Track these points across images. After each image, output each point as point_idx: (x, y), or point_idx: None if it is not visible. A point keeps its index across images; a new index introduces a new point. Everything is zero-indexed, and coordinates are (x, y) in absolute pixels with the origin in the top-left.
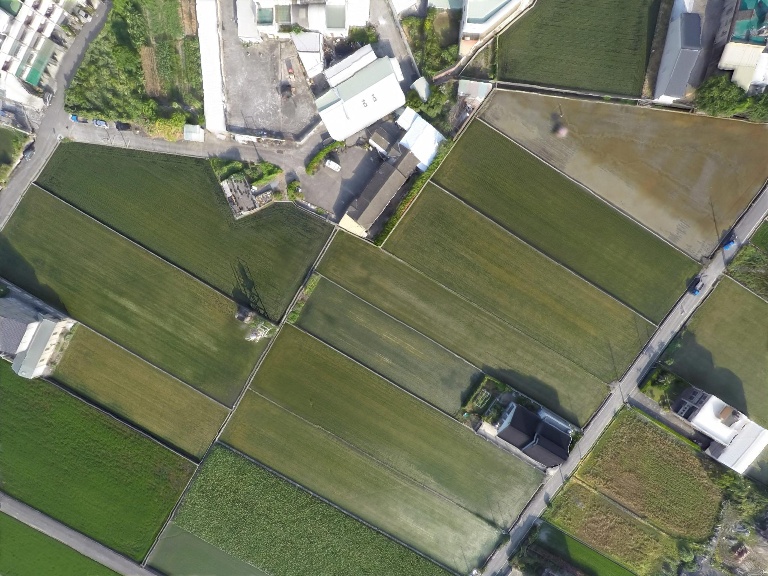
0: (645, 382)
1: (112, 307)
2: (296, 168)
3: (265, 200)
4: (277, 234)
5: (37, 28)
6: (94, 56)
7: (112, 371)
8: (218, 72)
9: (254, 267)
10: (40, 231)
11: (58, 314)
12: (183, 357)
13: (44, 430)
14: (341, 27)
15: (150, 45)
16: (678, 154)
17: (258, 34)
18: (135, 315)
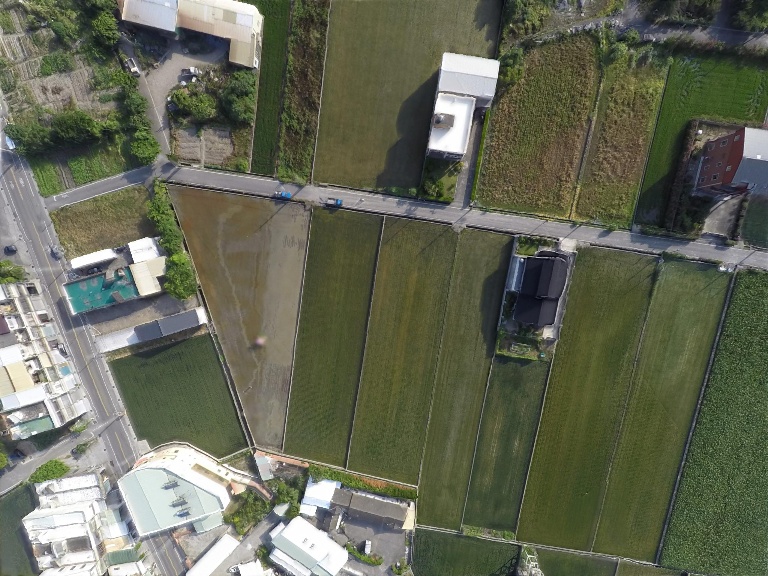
0: (442, 202)
1: None
2: (382, 571)
3: None
4: (441, 569)
5: None
6: None
7: None
8: None
9: None
10: None
11: None
12: None
13: None
14: None
15: None
16: (235, 279)
17: None
18: None
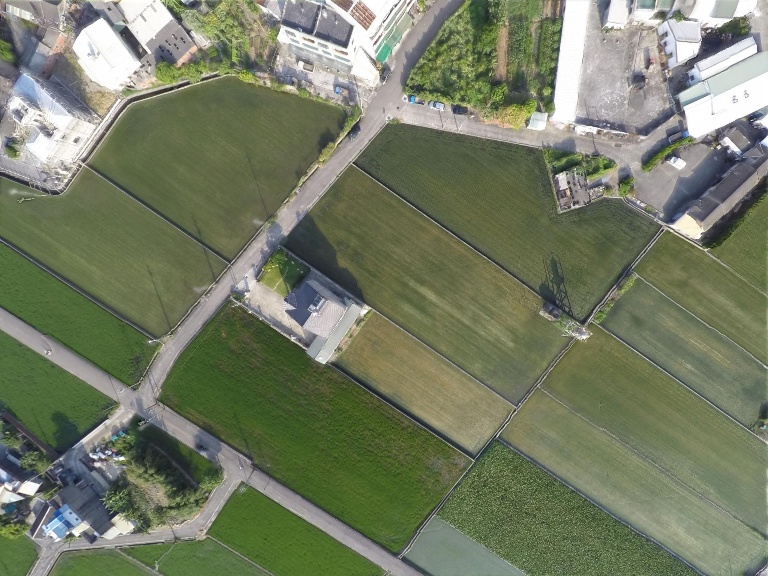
0: None
1: (411, 296)
2: (632, 163)
3: (596, 195)
4: (599, 231)
5: (408, 2)
6: (445, 34)
7: (398, 361)
8: (580, 58)
9: (567, 263)
10: (350, 214)
11: (357, 300)
12: (476, 351)
13: (319, 416)
14: (728, 17)
15: (505, 26)
16: None
17: (627, 20)
18: (434, 305)
